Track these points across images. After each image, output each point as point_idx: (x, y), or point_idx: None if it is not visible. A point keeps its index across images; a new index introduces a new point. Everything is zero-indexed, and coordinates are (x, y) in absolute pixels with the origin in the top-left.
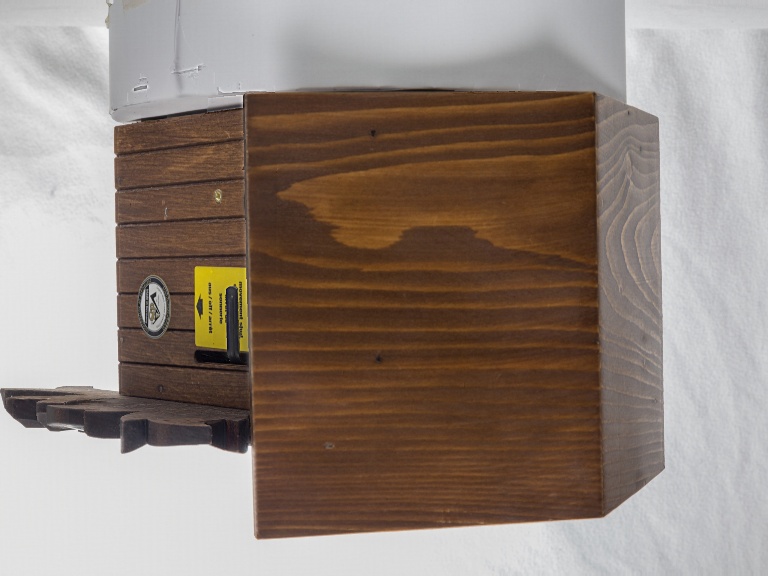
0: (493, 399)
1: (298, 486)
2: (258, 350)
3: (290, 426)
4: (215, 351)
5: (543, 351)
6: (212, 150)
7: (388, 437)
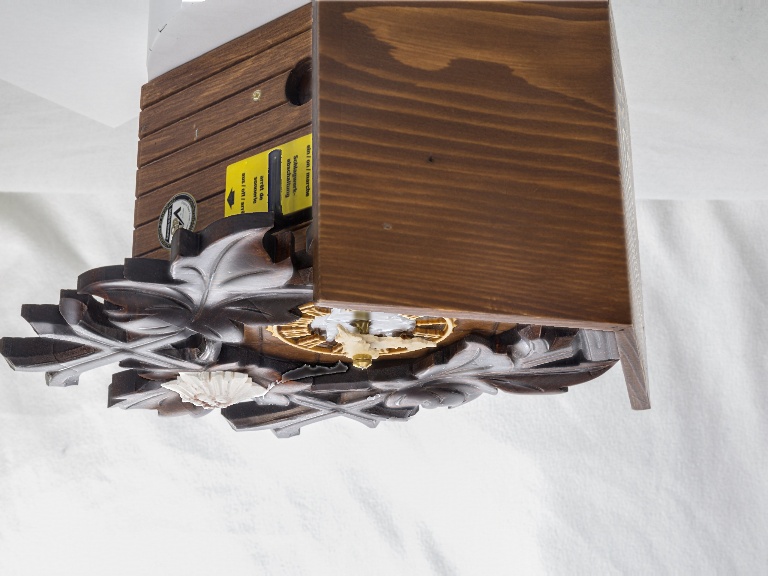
0: (531, 208)
1: (358, 257)
2: (324, 136)
3: (352, 205)
4: None
5: (573, 175)
6: (252, 61)
7: (439, 227)
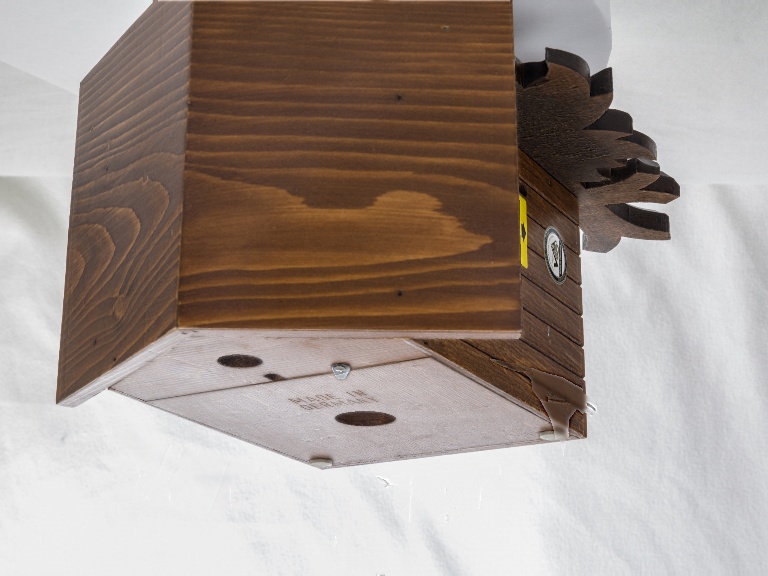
0: (293, 59)
1: None
2: (510, 109)
3: (481, 46)
4: None
5: (243, 97)
6: None
7: (392, 33)
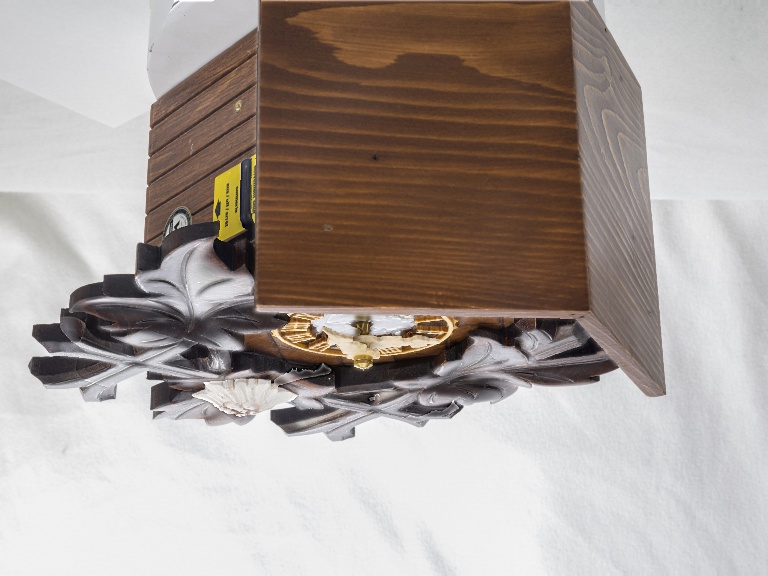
0: (482, 199)
1: (297, 261)
2: (264, 143)
3: (291, 209)
4: (230, 240)
5: (527, 162)
6: (235, 72)
7: (383, 225)
